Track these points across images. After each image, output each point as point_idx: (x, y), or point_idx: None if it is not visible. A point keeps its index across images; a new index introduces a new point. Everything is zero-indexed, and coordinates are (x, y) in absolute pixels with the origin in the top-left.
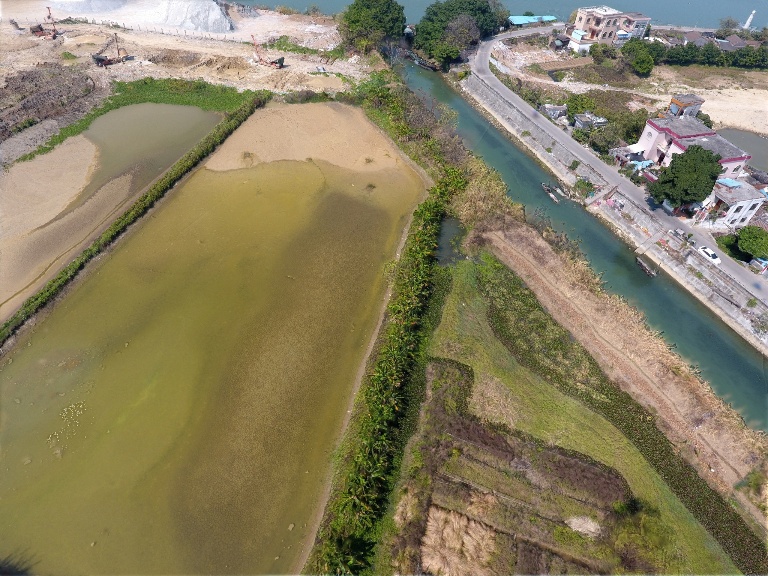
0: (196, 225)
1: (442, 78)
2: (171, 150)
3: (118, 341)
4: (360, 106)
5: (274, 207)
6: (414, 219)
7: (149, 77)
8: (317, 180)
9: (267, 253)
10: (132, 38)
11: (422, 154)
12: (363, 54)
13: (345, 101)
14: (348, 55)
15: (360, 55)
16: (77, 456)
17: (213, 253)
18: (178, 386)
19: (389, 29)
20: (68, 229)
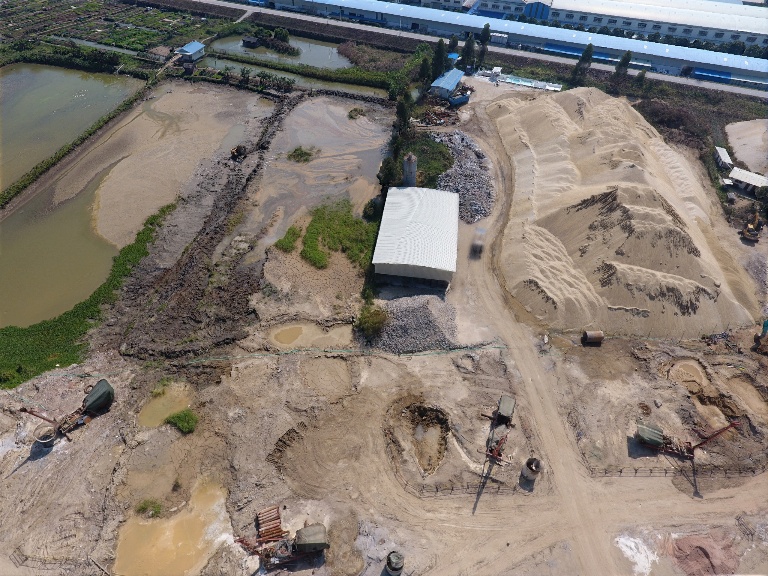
0: None
1: None
2: (4, 236)
3: (60, 112)
4: None
5: None
6: None
7: (8, 389)
8: None
9: None
10: None
11: None
12: None
13: None
14: None
15: None
16: None
17: None
18: None
19: None
20: (103, 157)
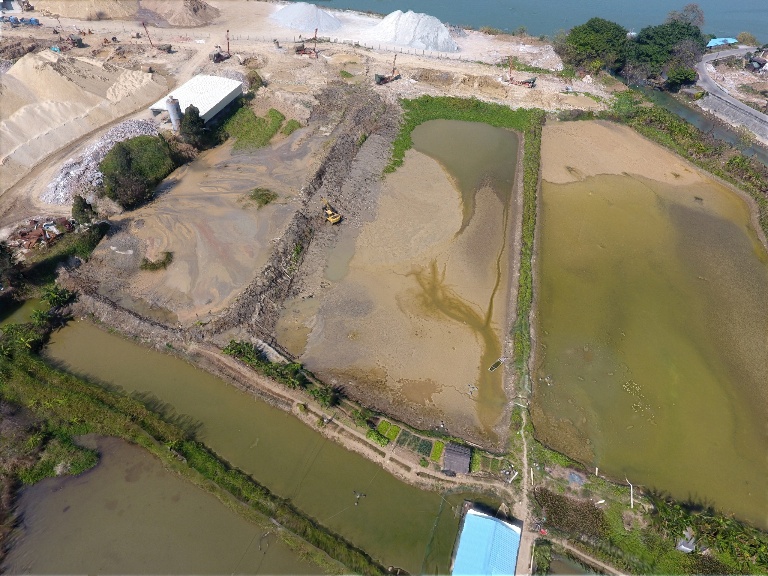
0: (585, 232)
1: (673, 98)
2: (501, 164)
3: (613, 331)
4: (626, 124)
5: (634, 217)
6: (767, 229)
7: (426, 95)
8: (648, 193)
9: (665, 257)
10: (380, 57)
11: (726, 170)
12: (593, 74)
13: (611, 119)
14: (580, 75)
15: (590, 75)
16: (667, 423)
17: (621, 257)
18: (695, 368)
19: (618, 52)
20: (483, 234)
